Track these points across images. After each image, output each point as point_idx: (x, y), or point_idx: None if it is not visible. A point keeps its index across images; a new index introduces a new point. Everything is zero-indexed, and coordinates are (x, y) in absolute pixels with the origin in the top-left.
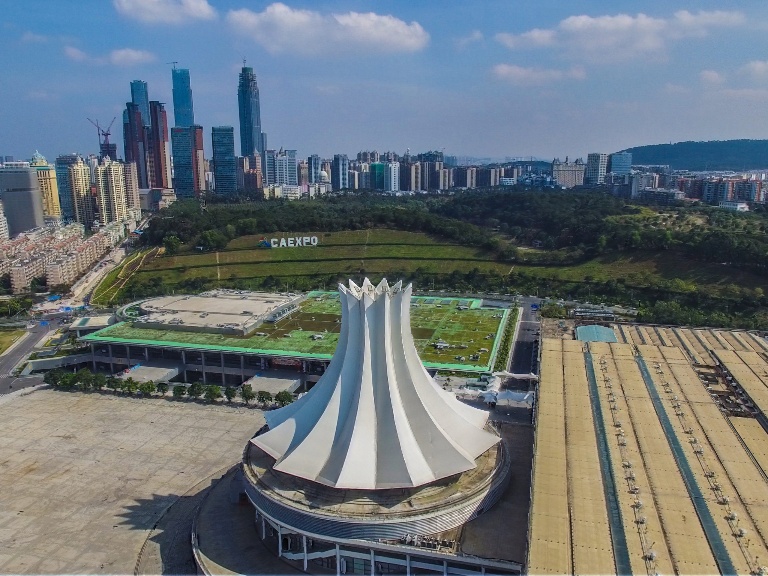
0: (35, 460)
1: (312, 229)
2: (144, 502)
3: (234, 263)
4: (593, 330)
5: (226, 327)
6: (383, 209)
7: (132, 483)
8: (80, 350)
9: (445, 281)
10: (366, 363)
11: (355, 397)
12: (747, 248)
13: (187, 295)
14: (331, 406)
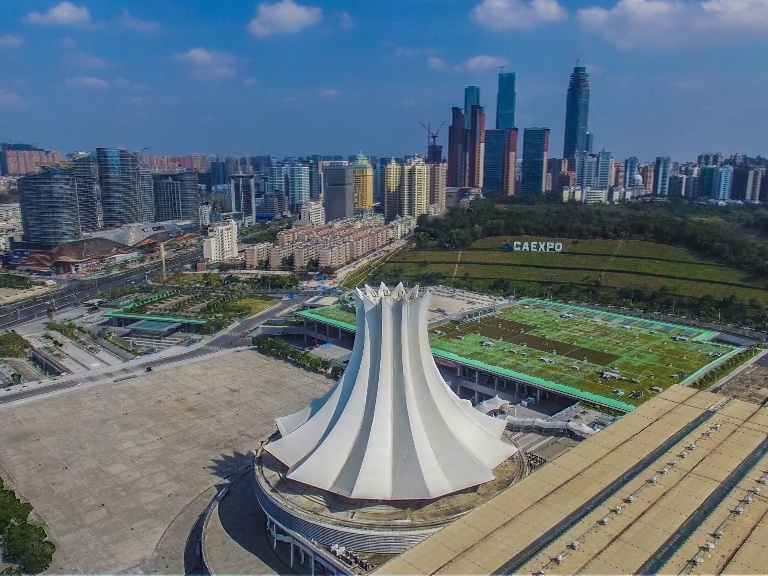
0: (200, 403)
1: (561, 235)
2: (238, 455)
3: (473, 262)
4: None
5: None
6: (656, 218)
7: (244, 438)
8: (300, 323)
9: (691, 306)
10: (363, 366)
11: None
12: None
13: (408, 287)
14: (330, 402)
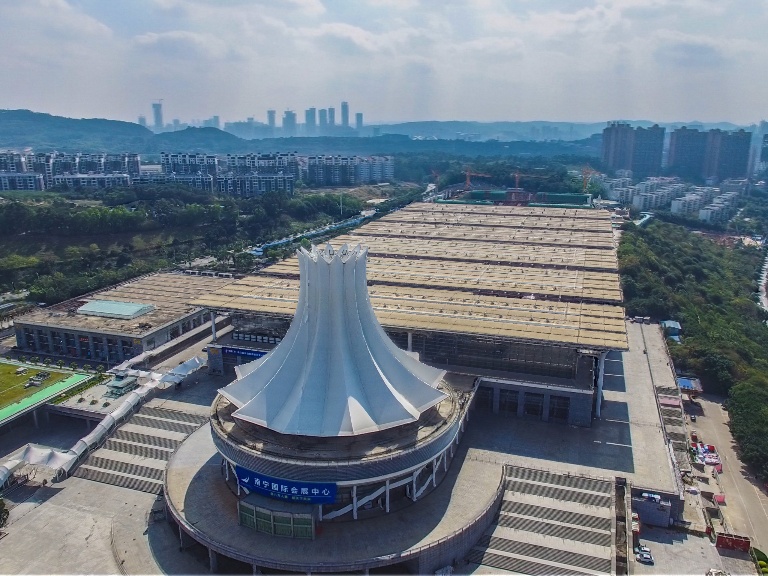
0: None
1: None
2: None
3: None
4: (105, 304)
5: None
6: None
7: None
8: None
9: None
10: None
11: (376, 345)
12: (47, 214)
13: None
14: None
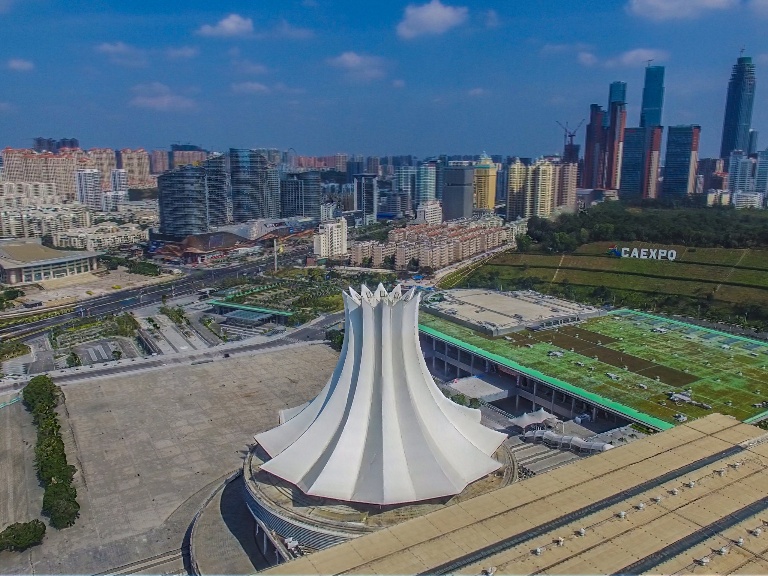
0: (258, 390)
1: (676, 242)
2: None
3: (575, 268)
4: None
5: (482, 325)
6: None
7: None
8: None
9: None
10: (347, 366)
11: None
12: None
13: (496, 291)
14: (319, 399)
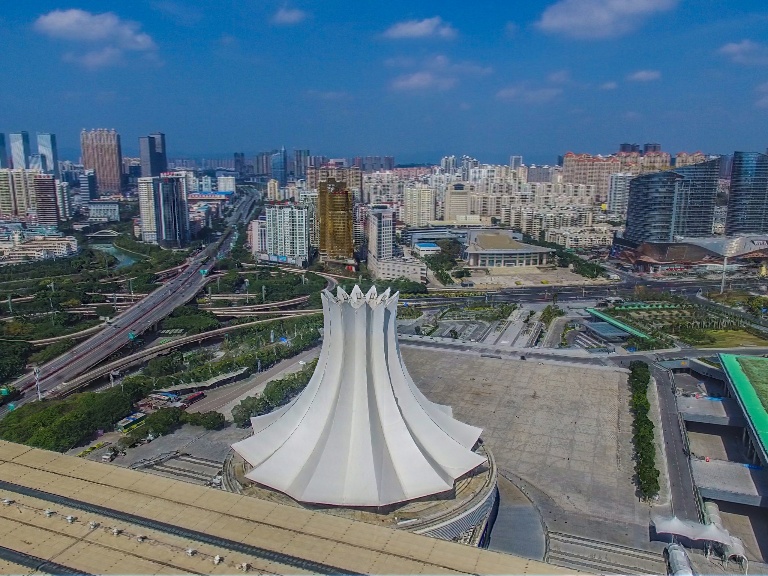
0: (493, 392)
1: None
2: None
3: None
4: None
5: None
6: None
7: None
8: None
9: None
10: None
11: None
12: None
13: None
14: None
